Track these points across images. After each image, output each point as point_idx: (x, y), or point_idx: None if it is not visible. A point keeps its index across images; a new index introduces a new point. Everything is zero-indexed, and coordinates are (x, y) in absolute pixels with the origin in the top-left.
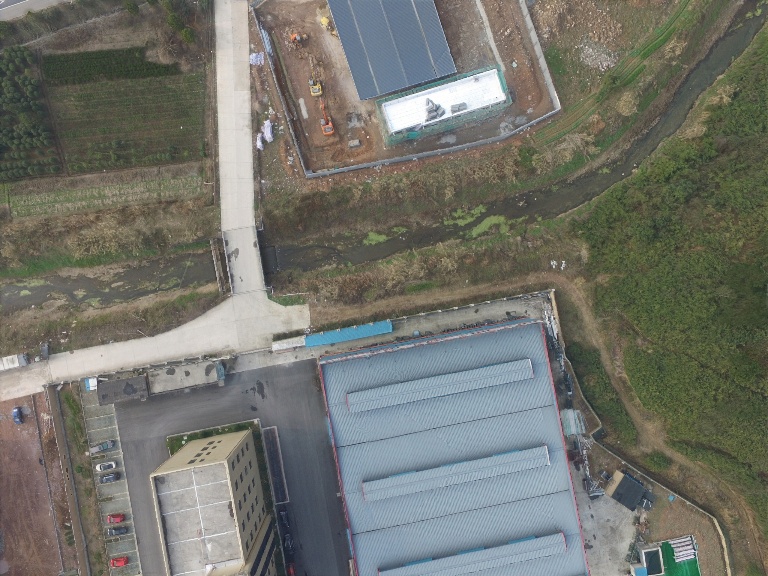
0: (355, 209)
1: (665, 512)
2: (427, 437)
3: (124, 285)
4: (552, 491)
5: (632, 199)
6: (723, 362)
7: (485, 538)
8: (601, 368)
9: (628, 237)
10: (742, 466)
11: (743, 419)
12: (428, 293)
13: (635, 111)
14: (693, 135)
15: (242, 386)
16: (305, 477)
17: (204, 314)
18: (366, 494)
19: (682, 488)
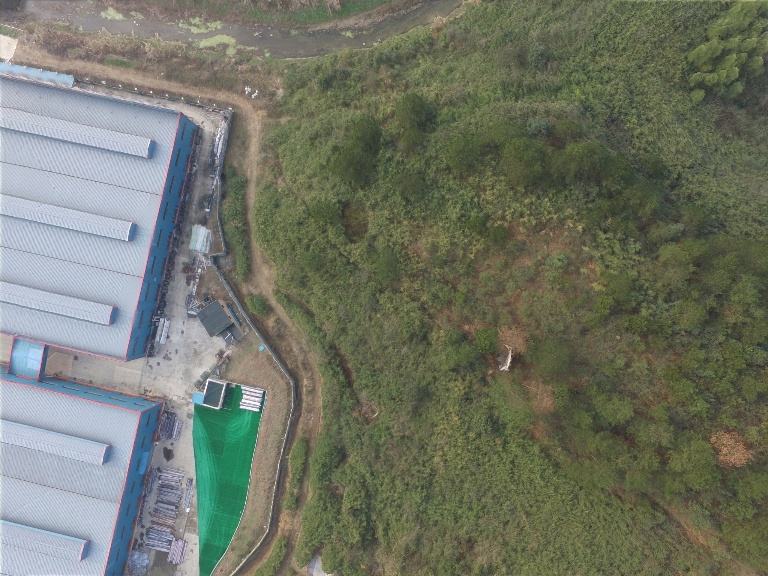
0: None
1: (249, 357)
2: (39, 176)
3: None
4: (128, 272)
5: (339, 54)
6: None
7: (50, 285)
8: (239, 195)
9: None
10: (318, 331)
11: (326, 279)
12: (123, 71)
13: None
14: (435, 24)
15: None
16: None
17: None
18: None
19: (279, 346)
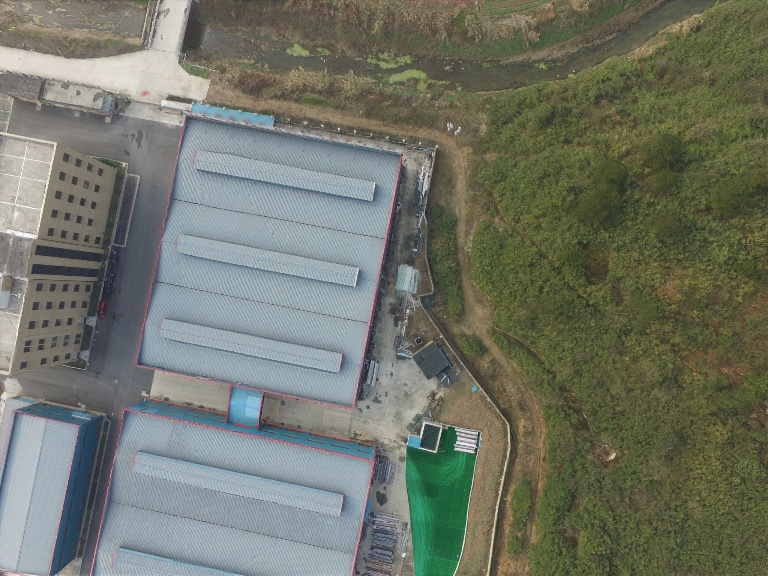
0: (289, 15)
1: (463, 398)
2: (256, 221)
3: (66, 13)
4: (351, 317)
5: (548, 88)
6: (559, 254)
7: (272, 333)
8: (452, 234)
9: (527, 121)
10: (547, 373)
11: (561, 321)
12: (321, 109)
13: (586, 7)
14: (639, 55)
15: (125, 129)
16: (147, 231)
17: (118, 56)
18: (179, 244)
19: (490, 386)
